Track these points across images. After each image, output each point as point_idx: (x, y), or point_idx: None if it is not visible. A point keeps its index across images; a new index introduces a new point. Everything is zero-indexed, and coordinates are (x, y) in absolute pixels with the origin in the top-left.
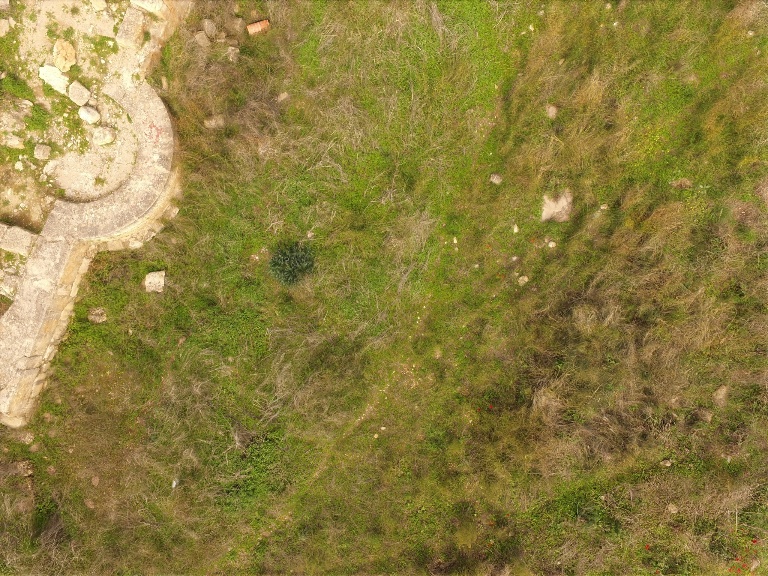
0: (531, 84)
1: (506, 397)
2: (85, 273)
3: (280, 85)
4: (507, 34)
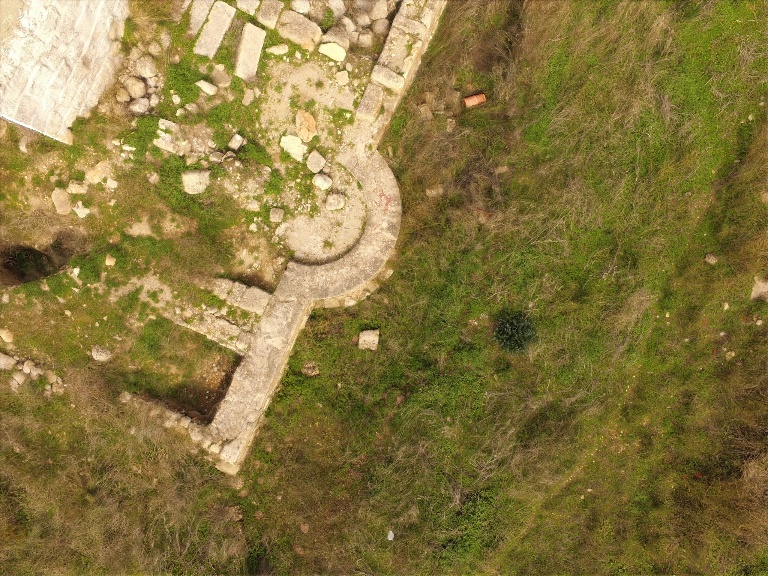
0: (753, 173)
1: (711, 466)
2: (303, 329)
3: (500, 159)
4: (727, 123)
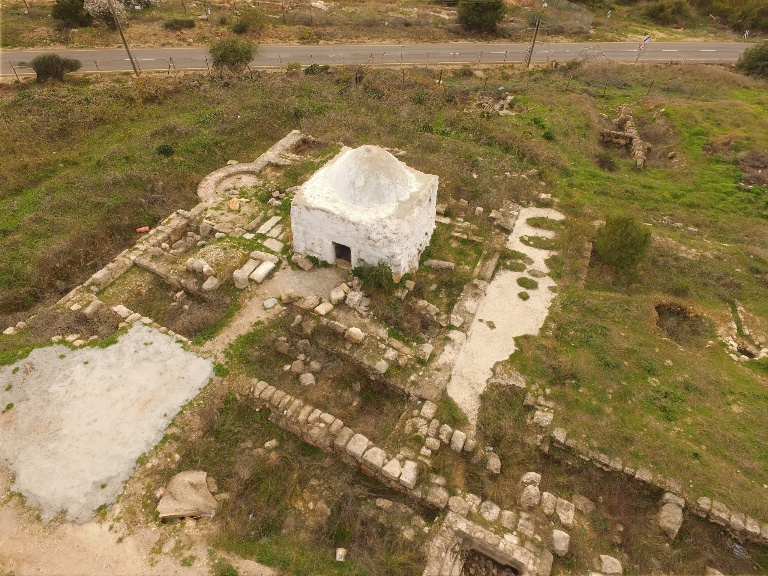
0: None
1: None
2: None
3: None
4: None
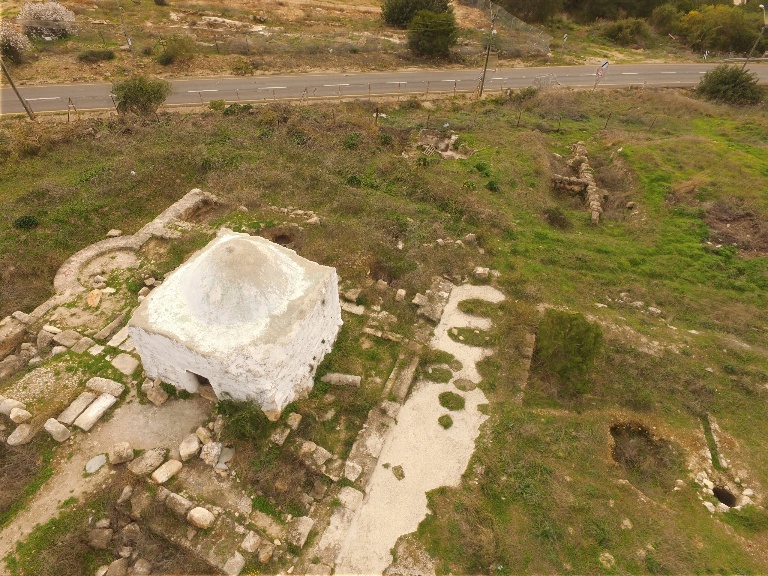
0: None
1: None
2: None
3: None
4: None
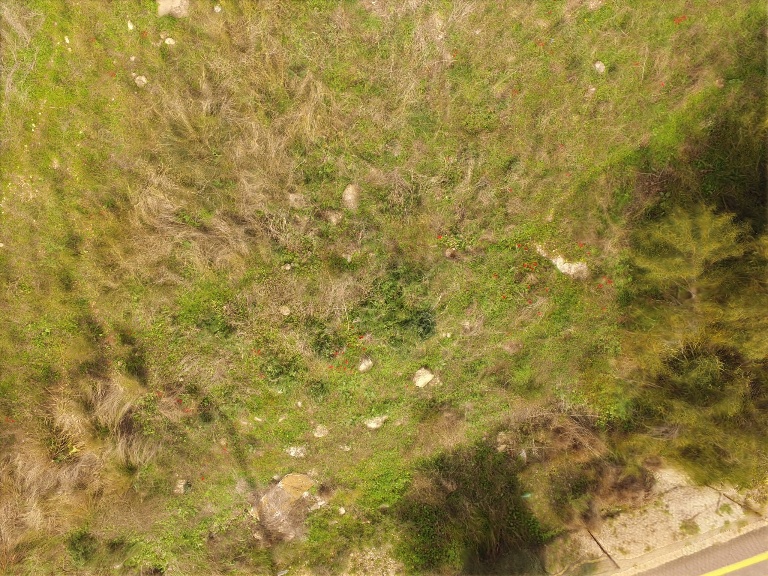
0: None
1: None
2: None
3: None
4: None
